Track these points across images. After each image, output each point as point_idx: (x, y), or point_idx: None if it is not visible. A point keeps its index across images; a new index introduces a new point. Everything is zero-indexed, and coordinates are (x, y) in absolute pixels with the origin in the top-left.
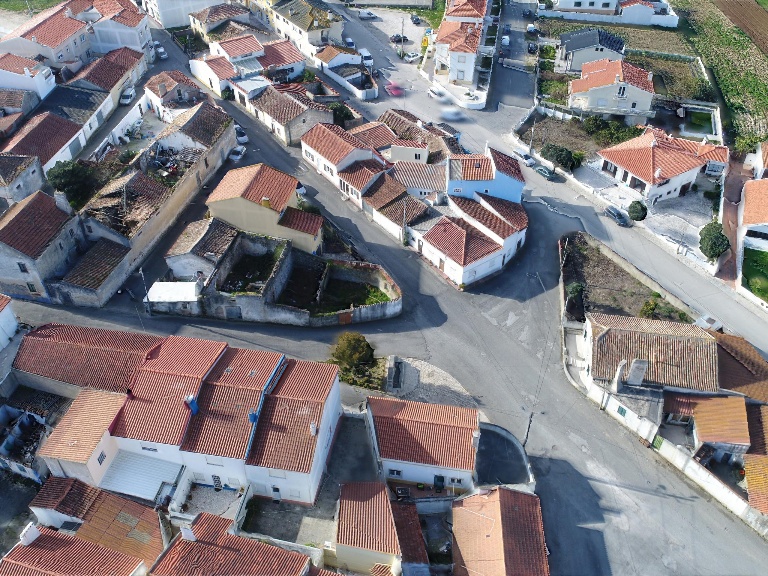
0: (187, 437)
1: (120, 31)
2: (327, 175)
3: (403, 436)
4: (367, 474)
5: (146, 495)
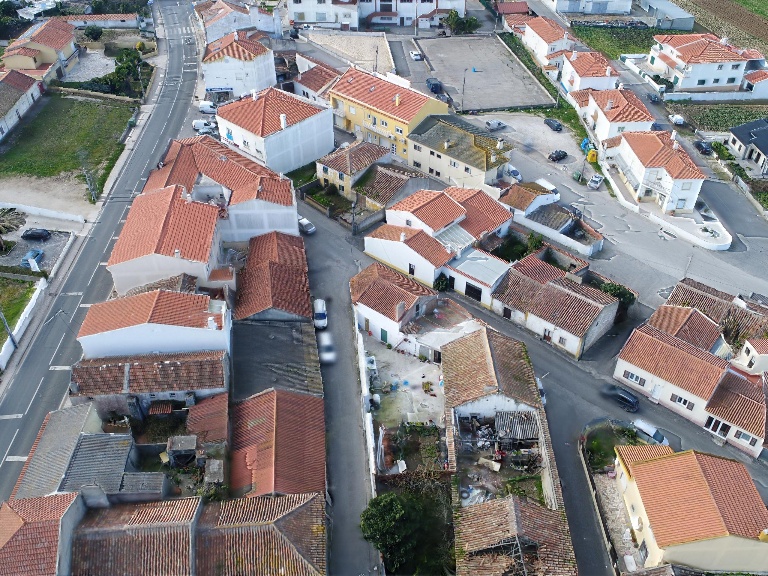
0: None
1: (269, 212)
2: (674, 406)
3: None
4: None
5: None
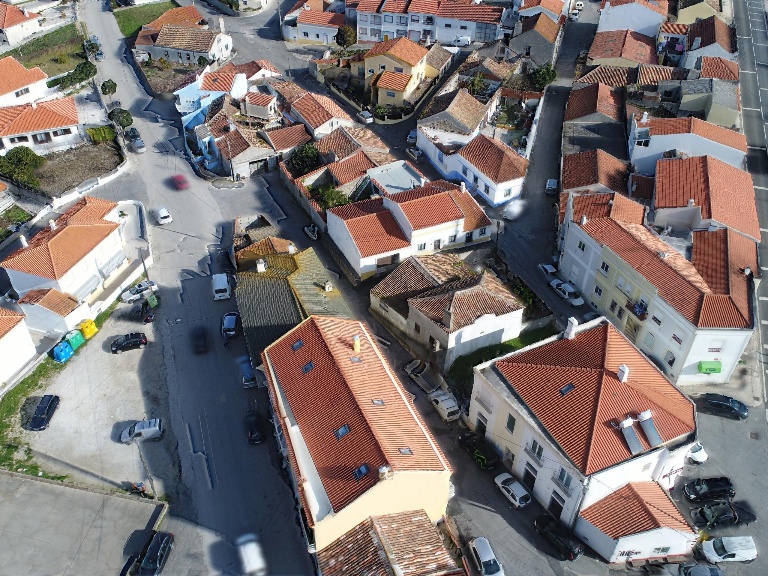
0: None
1: None
2: None
3: None
4: (351, 24)
5: None
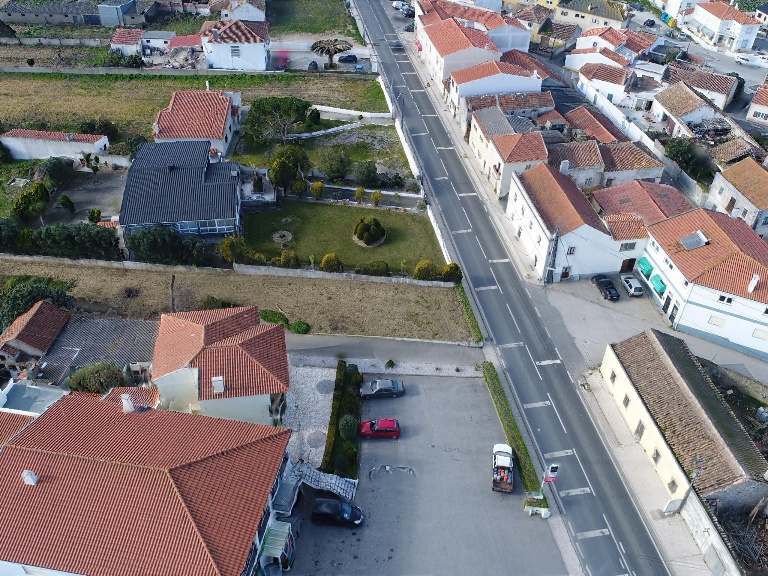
0: None
1: (514, 35)
2: None
3: None
4: None
5: None
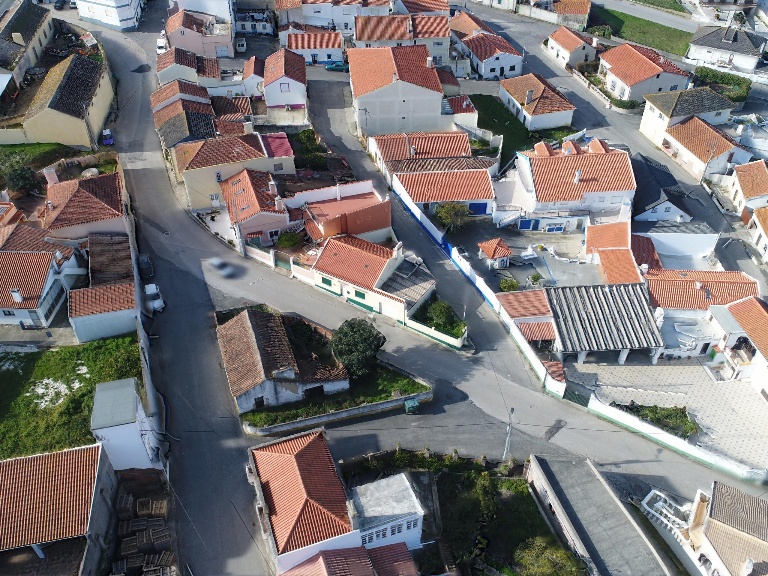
0: (334, 1)
1: None
2: None
3: (417, 4)
4: None
5: (325, 25)
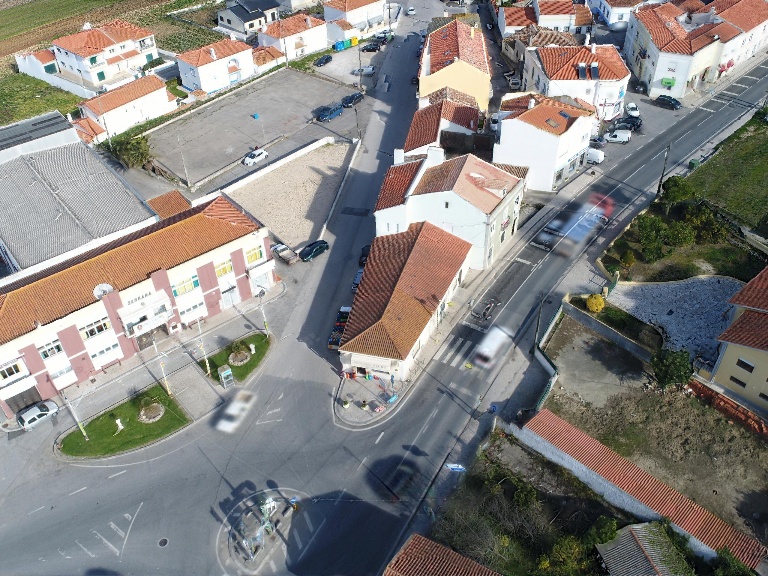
0: None
1: None
2: None
3: None
4: None
5: None
